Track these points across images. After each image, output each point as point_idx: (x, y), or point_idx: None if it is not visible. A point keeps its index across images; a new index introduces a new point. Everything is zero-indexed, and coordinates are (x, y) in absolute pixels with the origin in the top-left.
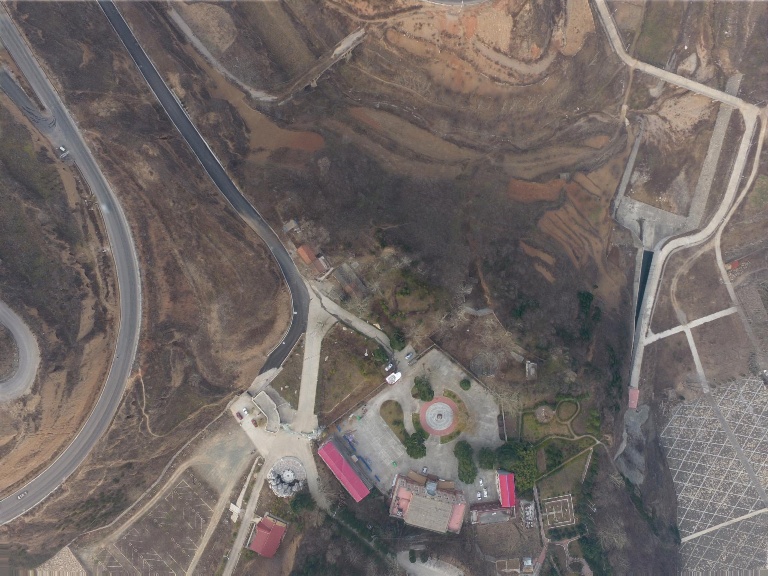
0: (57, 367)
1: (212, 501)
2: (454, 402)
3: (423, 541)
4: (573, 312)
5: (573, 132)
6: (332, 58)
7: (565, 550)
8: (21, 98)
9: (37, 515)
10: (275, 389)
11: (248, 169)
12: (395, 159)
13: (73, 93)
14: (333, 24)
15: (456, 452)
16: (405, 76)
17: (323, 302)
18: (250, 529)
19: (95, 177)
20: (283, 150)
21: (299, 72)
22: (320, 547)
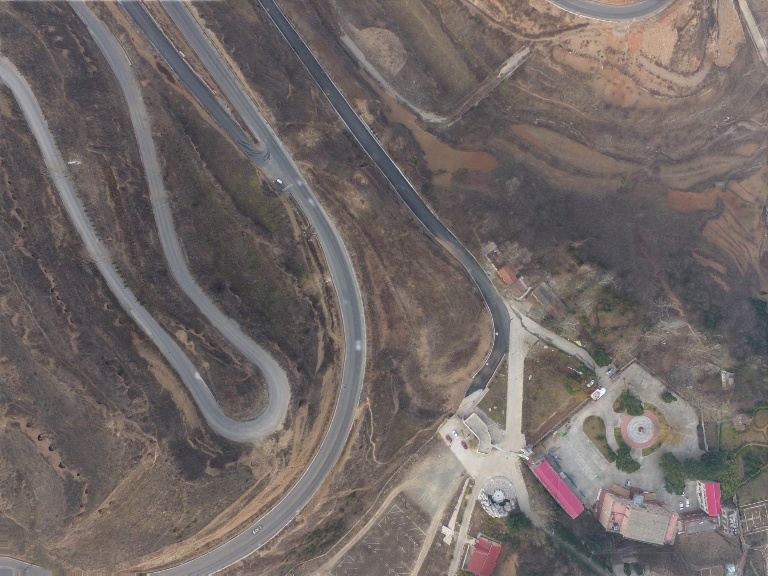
0: (301, 401)
1: (424, 525)
2: (654, 415)
3: (632, 553)
4: (755, 320)
5: (724, 141)
6: (499, 78)
7: (763, 555)
8: (236, 132)
9: (272, 549)
10: (483, 410)
11: (439, 192)
12: (559, 175)
13: (283, 125)
14: (494, 43)
15: (664, 464)
16: (565, 92)
17: (523, 322)
18: (464, 551)
19: (312, 208)
20: (463, 171)
21: (460, 92)
22: (546, 566)
